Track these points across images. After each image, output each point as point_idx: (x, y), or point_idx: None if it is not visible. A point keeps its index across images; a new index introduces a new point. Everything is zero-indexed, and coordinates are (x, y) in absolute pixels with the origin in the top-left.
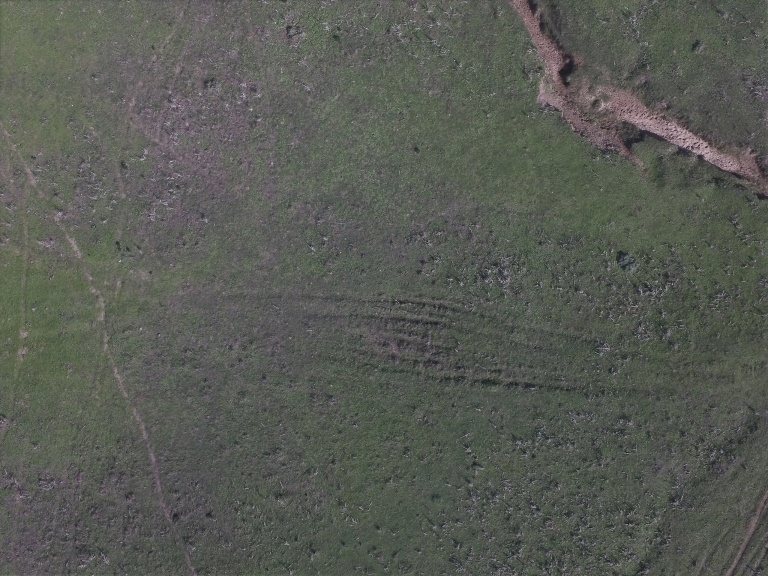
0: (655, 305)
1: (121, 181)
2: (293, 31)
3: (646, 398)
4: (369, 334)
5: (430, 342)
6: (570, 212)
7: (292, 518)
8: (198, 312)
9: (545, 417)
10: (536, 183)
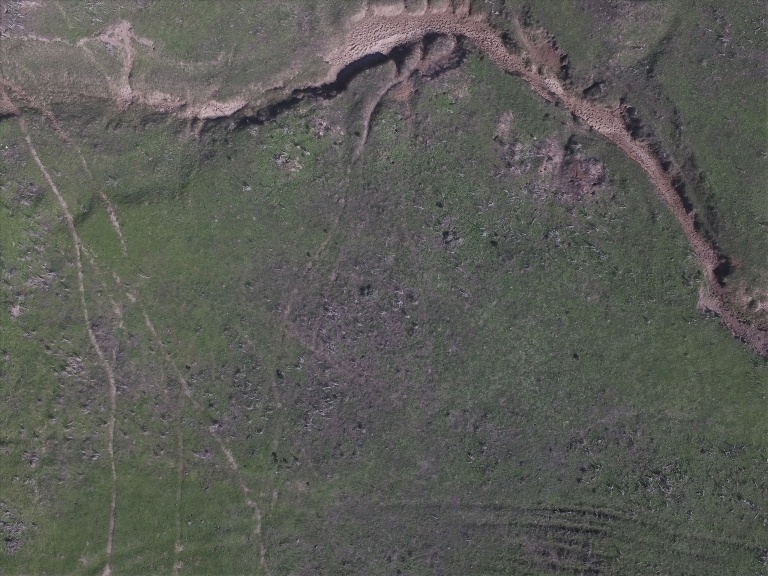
0: None
1: (276, 390)
2: (450, 237)
3: None
4: (528, 542)
5: (591, 551)
6: (732, 419)
7: None
8: (355, 523)
9: None
10: (697, 390)
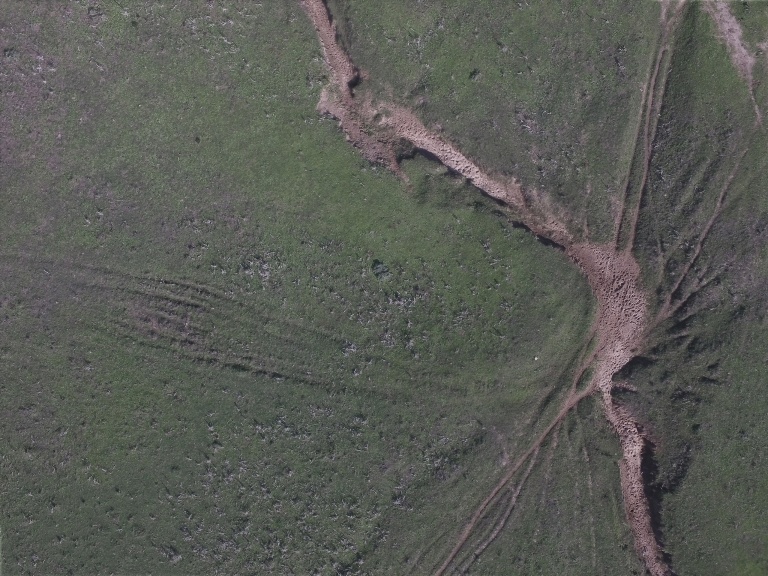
0: (403, 315)
1: None
2: (93, 12)
3: (383, 401)
4: (133, 308)
5: (189, 323)
6: (334, 217)
7: (39, 471)
8: None
9: (287, 407)
10: (306, 185)
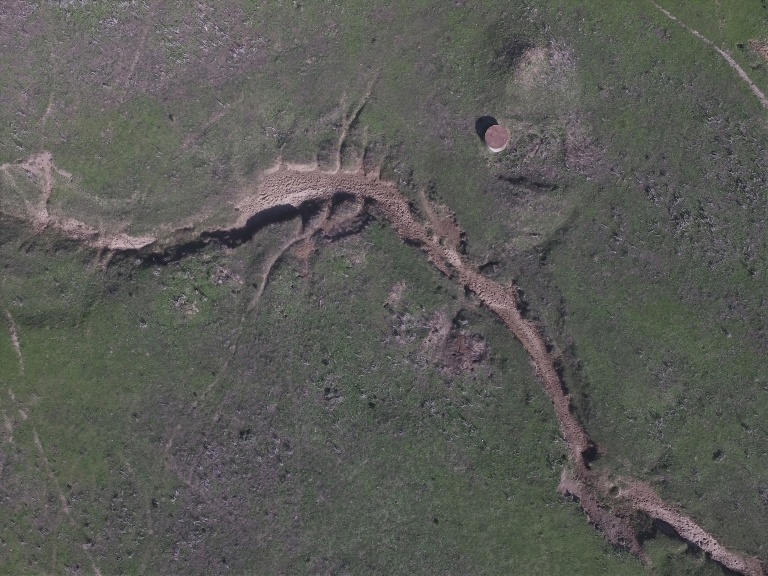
0: None
1: (150, 517)
2: (331, 395)
3: None
4: None
5: None
6: None
7: None
8: None
9: None
10: (547, 568)
